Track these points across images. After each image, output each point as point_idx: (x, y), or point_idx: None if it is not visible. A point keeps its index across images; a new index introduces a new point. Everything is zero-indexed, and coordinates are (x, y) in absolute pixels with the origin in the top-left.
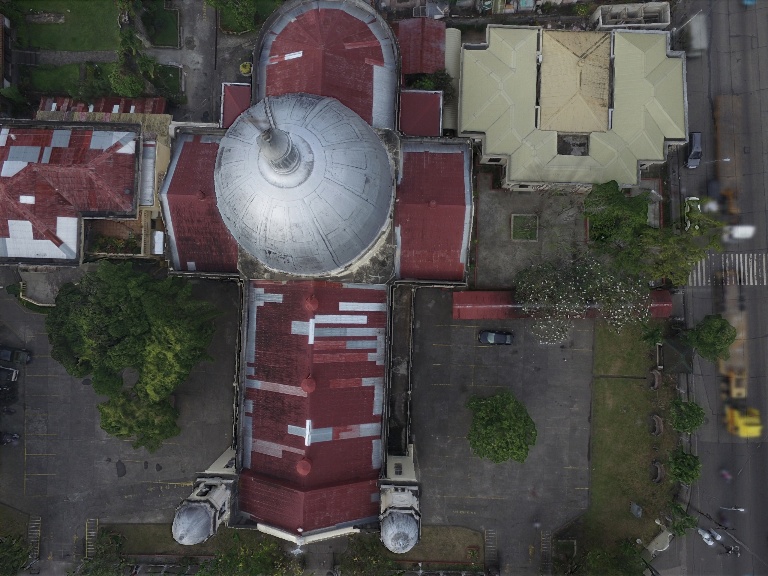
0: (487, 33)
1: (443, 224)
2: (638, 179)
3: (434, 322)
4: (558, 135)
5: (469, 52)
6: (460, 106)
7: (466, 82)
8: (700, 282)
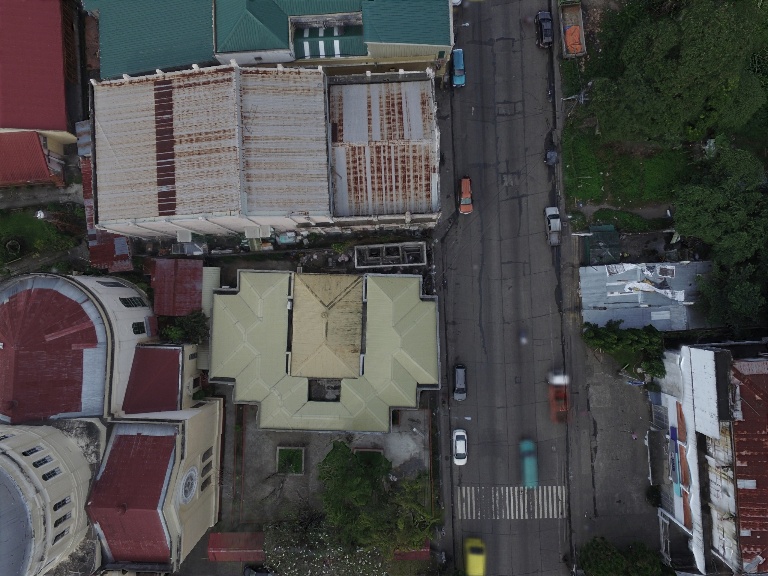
0: (237, 278)
1: (140, 522)
2: (390, 426)
3: (200, 555)
4: (311, 379)
5: (219, 297)
6: (209, 353)
7: (216, 328)
8: (470, 515)
